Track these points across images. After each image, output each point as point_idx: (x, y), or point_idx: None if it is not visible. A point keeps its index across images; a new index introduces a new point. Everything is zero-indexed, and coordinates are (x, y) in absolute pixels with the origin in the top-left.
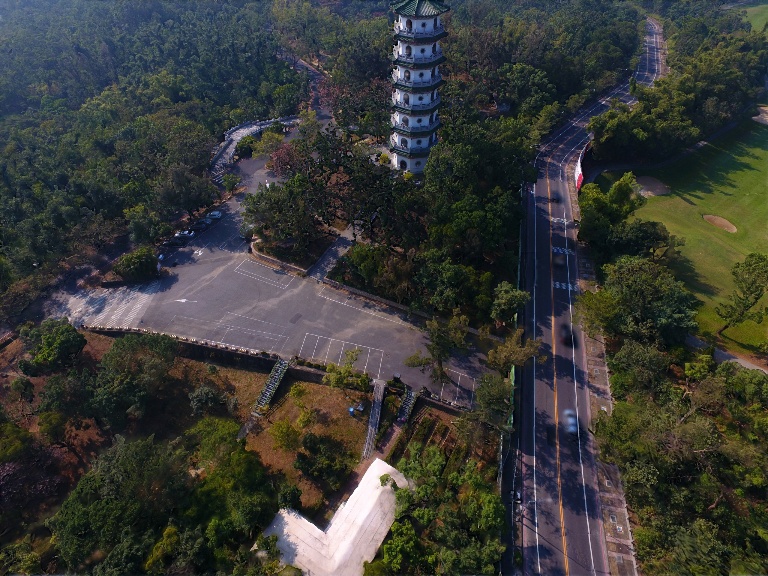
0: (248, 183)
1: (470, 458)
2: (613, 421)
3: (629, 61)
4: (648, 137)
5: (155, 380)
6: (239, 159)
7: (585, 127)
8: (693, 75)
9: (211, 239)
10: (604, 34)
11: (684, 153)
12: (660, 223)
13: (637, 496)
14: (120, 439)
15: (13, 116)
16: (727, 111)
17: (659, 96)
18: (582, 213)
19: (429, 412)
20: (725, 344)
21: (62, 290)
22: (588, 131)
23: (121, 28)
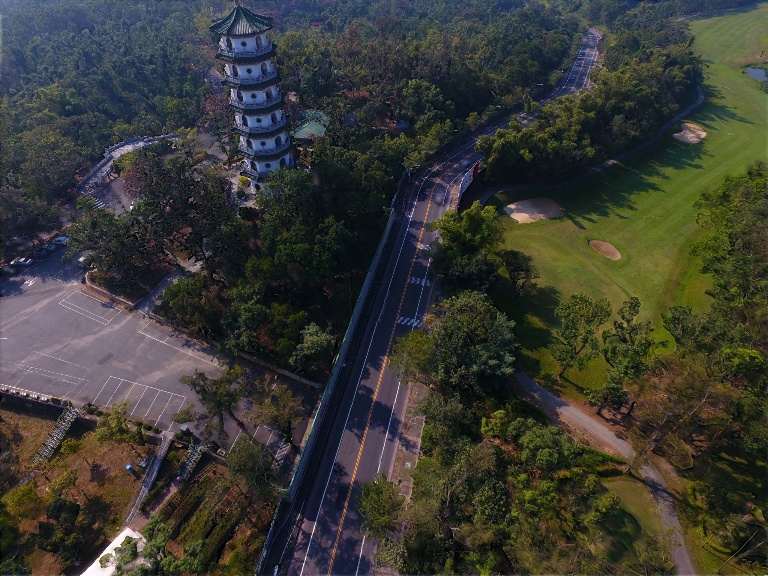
0: (113, 204)
1: (241, 525)
2: (373, 491)
3: (550, 76)
4: (541, 157)
5: None
6: (115, 178)
7: None
8: (603, 92)
9: (48, 267)
10: (525, 48)
11: (589, 173)
12: (521, 253)
13: (408, 572)
14: None
15: None
16: (637, 129)
17: (557, 114)
18: (443, 241)
19: (213, 470)
20: (562, 388)
21: None
22: (477, 151)
23: (42, 37)
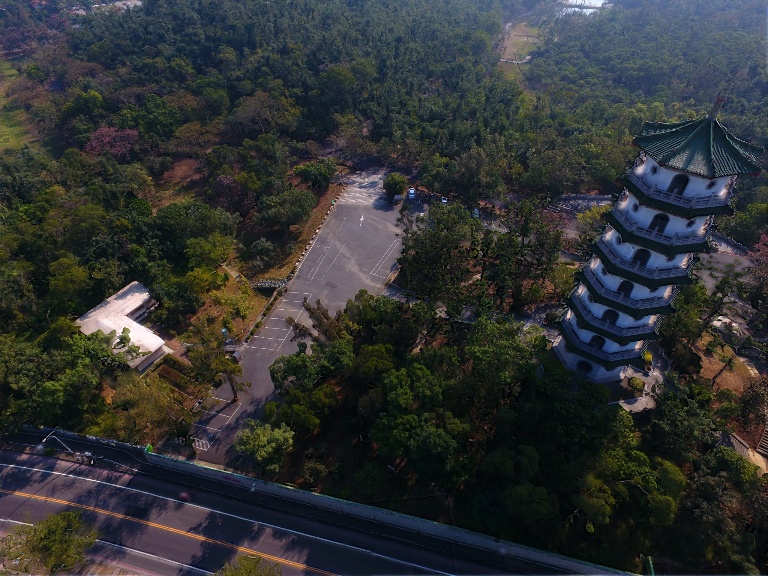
0: None
1: None
2: (55, 522)
3: None
4: None
5: (273, 216)
6: None
7: None
8: None
9: None
10: None
11: None
12: None
13: None
14: (236, 215)
15: (625, 90)
16: None
17: None
18: None
19: None
20: None
21: (389, 169)
22: None
23: None
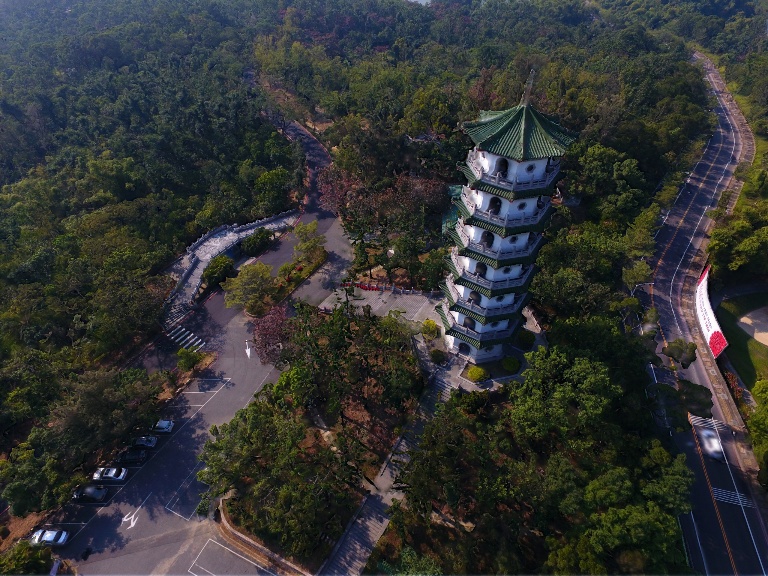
0: (219, 345)
1: None
2: None
3: (708, 120)
4: None
5: None
6: None
7: (681, 226)
8: None
9: (153, 484)
10: (674, 86)
11: None
12: None
13: None
14: None
15: None
16: None
17: None
18: (756, 429)
19: None
20: None
21: None
22: (709, 251)
23: (67, 73)
